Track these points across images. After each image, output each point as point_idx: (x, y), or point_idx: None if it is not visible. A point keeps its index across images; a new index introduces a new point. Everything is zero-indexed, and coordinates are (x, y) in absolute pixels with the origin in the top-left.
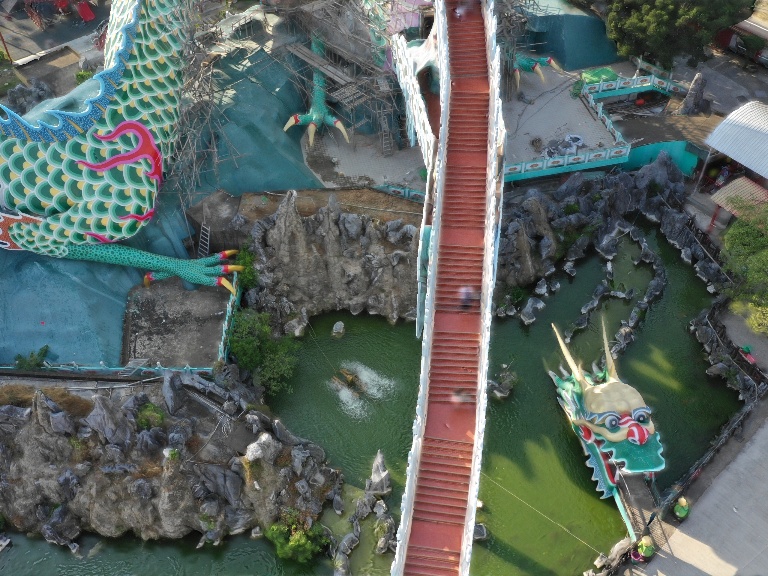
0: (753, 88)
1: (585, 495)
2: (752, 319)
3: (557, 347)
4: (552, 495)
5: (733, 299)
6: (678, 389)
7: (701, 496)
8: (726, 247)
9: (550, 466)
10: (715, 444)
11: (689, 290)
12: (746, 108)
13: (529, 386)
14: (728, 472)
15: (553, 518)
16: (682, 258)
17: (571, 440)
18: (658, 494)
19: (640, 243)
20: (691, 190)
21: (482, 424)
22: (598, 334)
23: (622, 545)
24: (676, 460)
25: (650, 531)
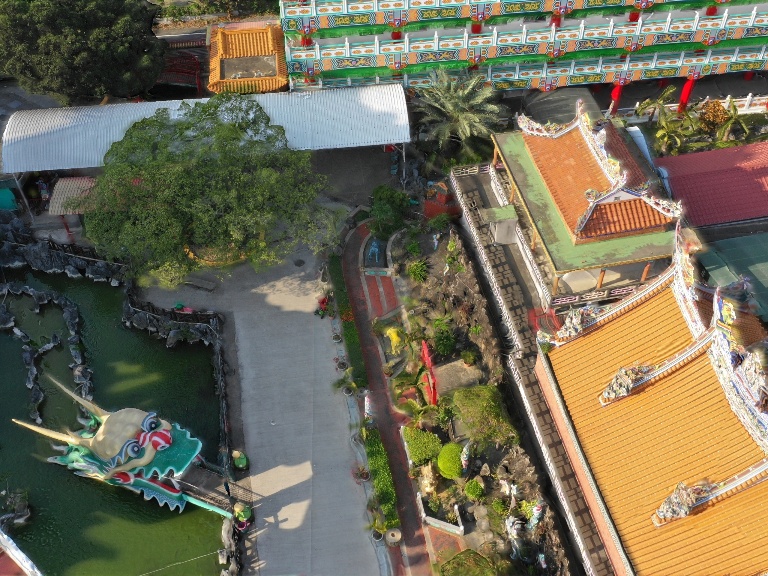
0: (4, 104)
1: (167, 523)
2: (162, 281)
3: (35, 435)
4: (143, 551)
5: (136, 278)
6: (160, 378)
7: (244, 437)
8: (95, 243)
9: (120, 531)
10: (220, 392)
11: (99, 297)
12: (12, 123)
13: (42, 488)
14: (246, 403)
15: (160, 567)
16: (71, 277)
17: (117, 494)
18: (216, 467)
19: (26, 293)
20: (28, 219)
21: (26, 563)
22: (60, 393)
23: (226, 529)
24: (206, 430)
25: (235, 498)
